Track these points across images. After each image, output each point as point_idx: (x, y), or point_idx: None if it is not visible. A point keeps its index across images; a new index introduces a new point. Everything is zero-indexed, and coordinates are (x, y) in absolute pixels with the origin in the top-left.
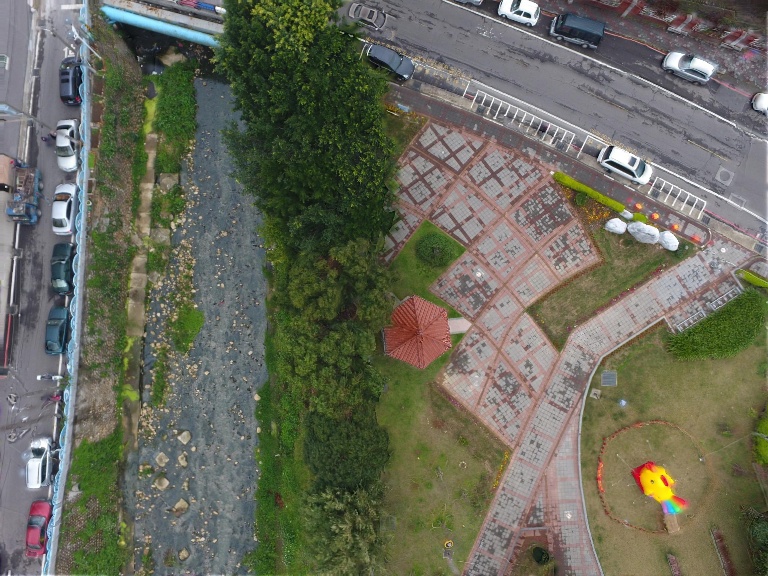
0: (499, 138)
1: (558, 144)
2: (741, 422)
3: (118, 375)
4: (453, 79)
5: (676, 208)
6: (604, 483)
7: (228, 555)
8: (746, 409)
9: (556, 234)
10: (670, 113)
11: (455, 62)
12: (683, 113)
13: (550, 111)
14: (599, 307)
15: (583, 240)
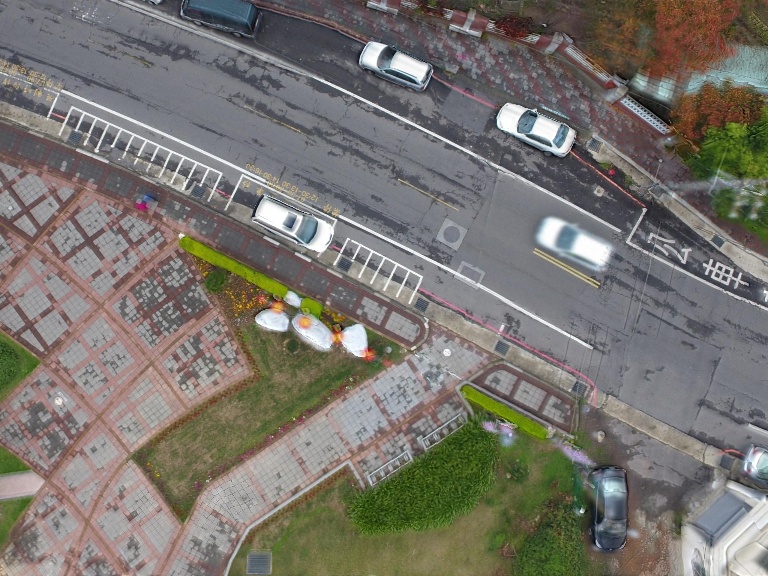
0: (100, 183)
1: (196, 189)
2: None
3: None
4: (33, 90)
5: (376, 287)
6: None
7: None
8: None
9: (183, 334)
10: (371, 137)
11: (37, 63)
12: (391, 136)
13: (184, 138)
14: (247, 448)
15: (226, 342)
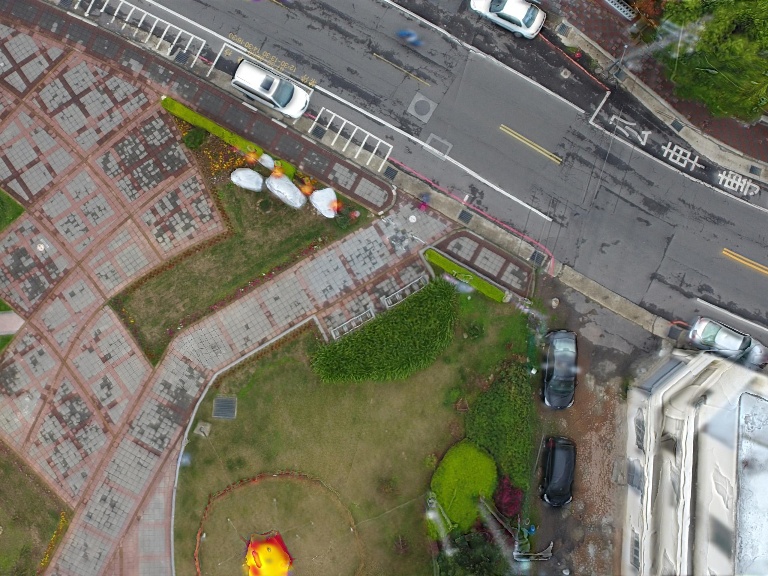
0: (89, 45)
1: (181, 55)
2: (416, 475)
3: None
4: None
5: (348, 155)
6: (207, 561)
7: None
8: (425, 456)
9: (162, 190)
10: (350, 12)
11: None
12: (369, 13)
13: (171, 6)
14: (218, 300)
15: (202, 199)
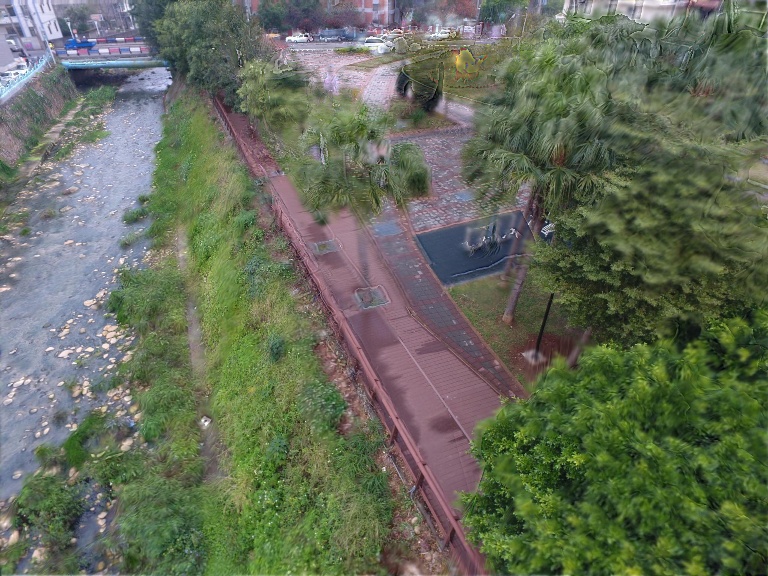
0: None
1: None
2: None
3: (23, 152)
4: None
5: None
6: None
7: (121, 201)
8: None
9: None
10: None
11: None
12: None
13: (331, 48)
14: None
15: None
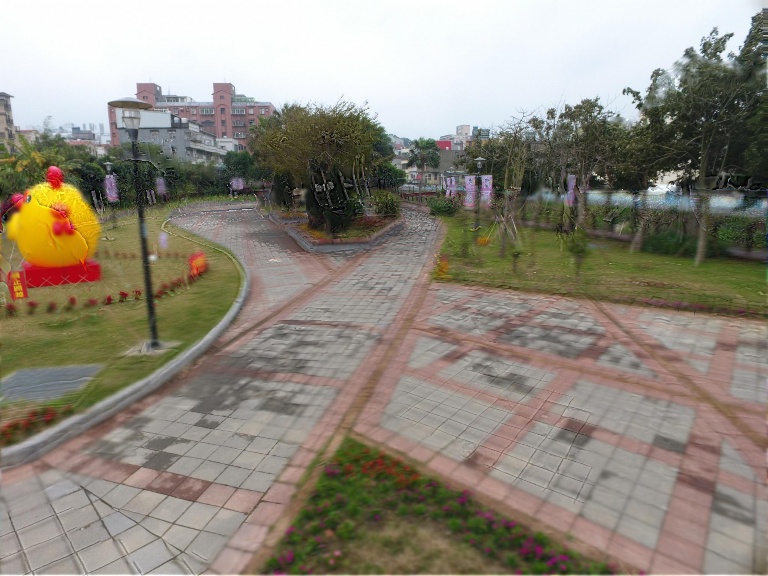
0: None
1: None
2: None
3: None
4: None
5: None
6: None
7: None
8: None
9: None
10: None
11: None
12: None
13: None
14: None
15: None
